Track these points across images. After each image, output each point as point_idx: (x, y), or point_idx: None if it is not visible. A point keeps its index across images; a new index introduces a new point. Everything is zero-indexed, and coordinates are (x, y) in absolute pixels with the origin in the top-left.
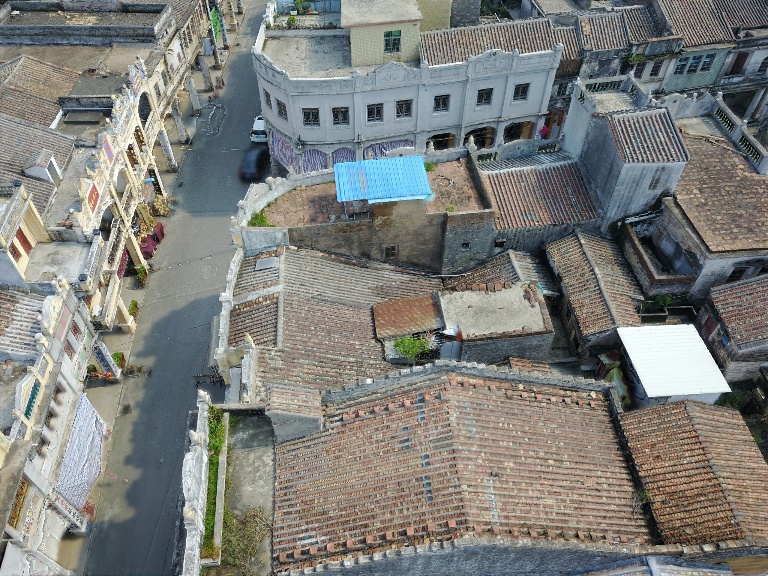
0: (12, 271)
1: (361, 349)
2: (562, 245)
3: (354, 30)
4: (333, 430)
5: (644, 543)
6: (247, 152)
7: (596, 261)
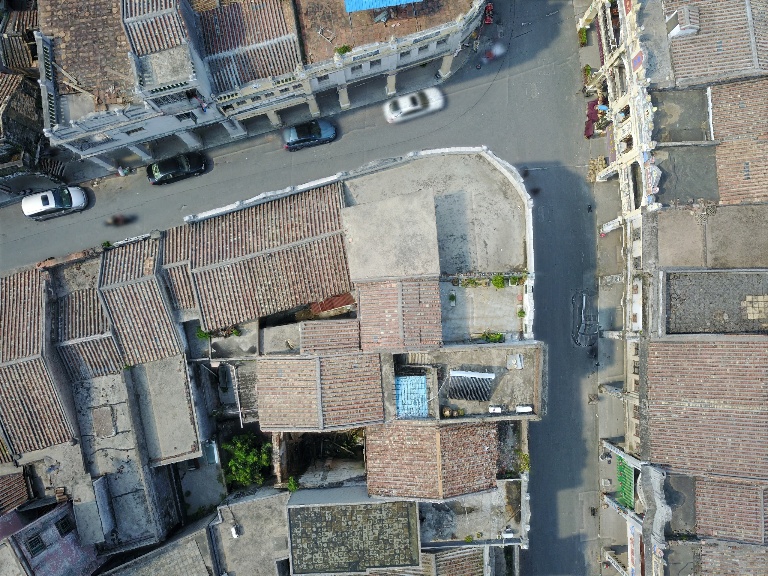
0: None
1: None
2: (233, 2)
3: None
4: None
5: None
6: None
7: None
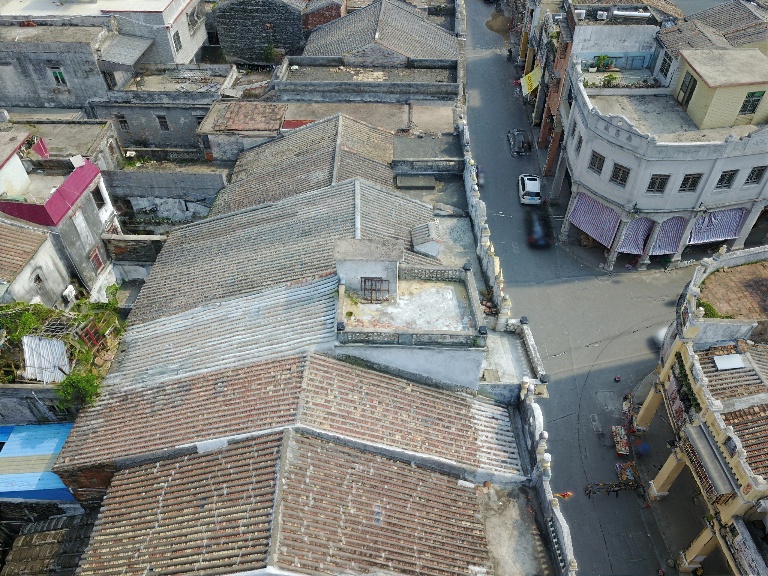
0: (473, 371)
1: None
2: None
3: (719, 91)
4: None
5: None
6: (520, 215)
7: None
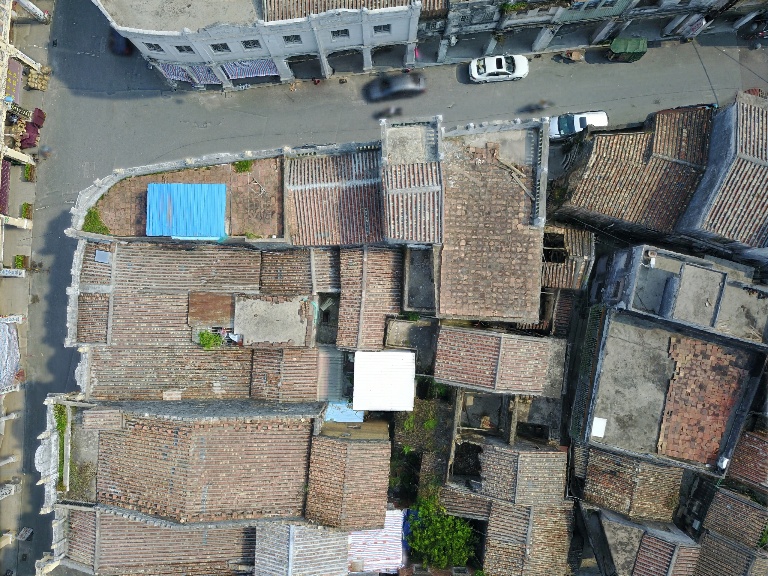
0: None
1: (175, 335)
2: (351, 256)
3: None
4: (130, 430)
5: (296, 512)
6: None
7: (369, 281)
